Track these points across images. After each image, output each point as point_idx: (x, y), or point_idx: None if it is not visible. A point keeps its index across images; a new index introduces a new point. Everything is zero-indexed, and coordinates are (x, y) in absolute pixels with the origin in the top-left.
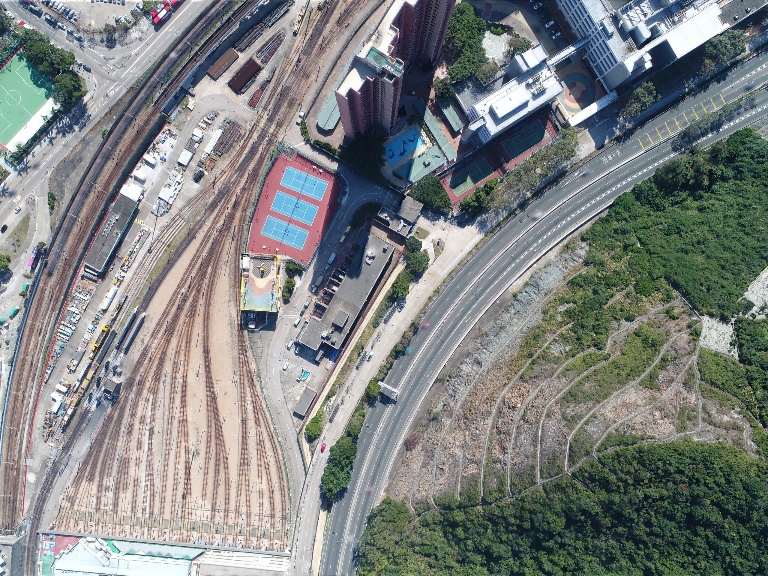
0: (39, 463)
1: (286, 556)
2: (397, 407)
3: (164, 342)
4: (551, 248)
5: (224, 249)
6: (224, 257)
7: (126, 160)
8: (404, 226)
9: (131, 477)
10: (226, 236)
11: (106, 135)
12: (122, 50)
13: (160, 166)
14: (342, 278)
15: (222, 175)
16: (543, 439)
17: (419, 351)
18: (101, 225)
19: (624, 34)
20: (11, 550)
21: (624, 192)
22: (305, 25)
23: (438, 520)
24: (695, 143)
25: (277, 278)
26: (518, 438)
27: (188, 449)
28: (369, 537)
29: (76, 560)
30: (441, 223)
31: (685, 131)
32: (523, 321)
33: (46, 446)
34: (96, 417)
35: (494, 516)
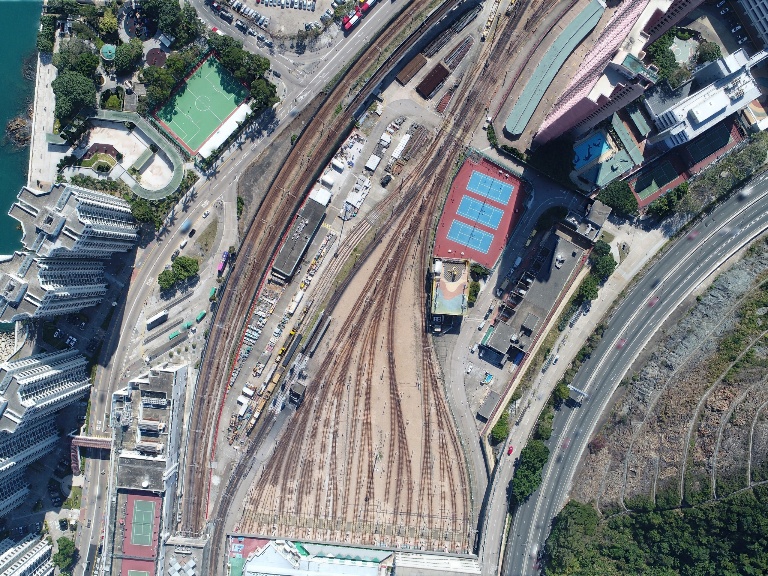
0: (224, 466)
1: (473, 559)
2: (582, 410)
3: (349, 345)
4: (735, 252)
5: (410, 253)
6: (409, 261)
7: (316, 165)
8: (591, 230)
9: (315, 480)
10: (412, 240)
11: (296, 140)
12: (311, 56)
13: (347, 171)
14: (530, 282)
15: (409, 180)
16: (755, 442)
17: (604, 354)
18: (288, 229)
19: None
20: (201, 552)
21: None
22: (493, 30)
23: (629, 523)
24: None
25: (468, 282)
26: (725, 441)
27: (371, 452)
28: (563, 540)
29: (267, 562)
30: (626, 227)
31: None
32: (715, 324)
33: (231, 449)
34: (280, 420)
35: (696, 519)
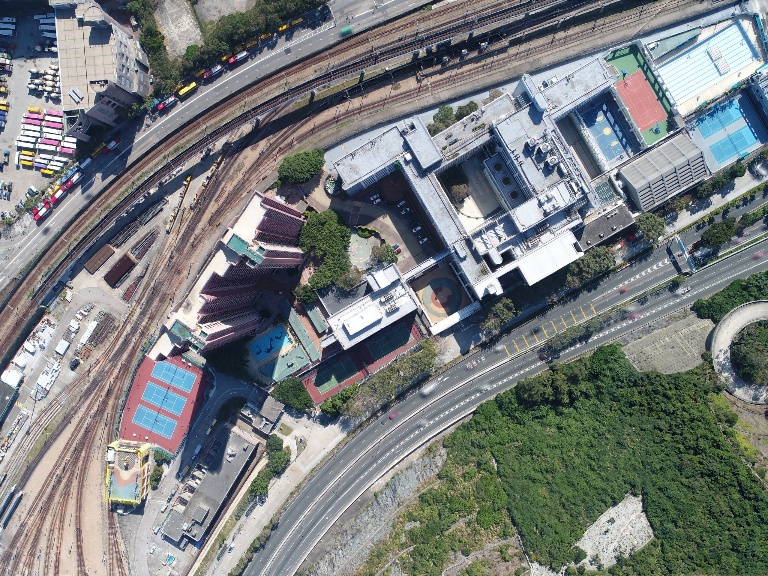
0: None
1: None
2: None
3: (39, 520)
4: (413, 450)
5: (97, 434)
6: (97, 442)
7: (6, 349)
8: (266, 424)
9: None
10: (99, 422)
11: None
12: (6, 243)
13: (39, 353)
14: (205, 472)
15: (97, 364)
16: None
17: (279, 545)
18: None
19: (478, 257)
20: None
21: (487, 400)
22: (178, 223)
23: None
24: (563, 353)
25: (140, 471)
26: None
27: None
28: None
29: None
30: (304, 421)
31: None
32: (375, 530)
33: None
34: None
35: None
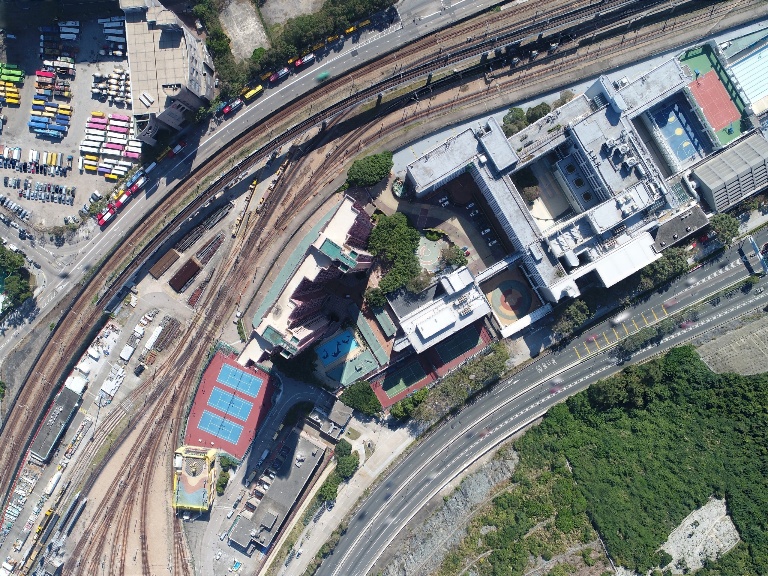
0: None
1: None
2: None
3: (104, 526)
4: (483, 454)
5: (162, 440)
6: (162, 448)
7: (70, 355)
8: (335, 429)
9: None
10: (164, 428)
11: (53, 329)
12: (70, 248)
13: (103, 359)
14: (273, 477)
15: (161, 370)
16: None
17: (348, 551)
18: (47, 413)
19: (553, 259)
20: None
21: (558, 403)
22: (244, 227)
23: None
24: (634, 354)
25: (208, 477)
26: None
27: None
28: None
29: None
30: (373, 425)
31: (623, 342)
32: (448, 534)
33: None
34: None
35: None
